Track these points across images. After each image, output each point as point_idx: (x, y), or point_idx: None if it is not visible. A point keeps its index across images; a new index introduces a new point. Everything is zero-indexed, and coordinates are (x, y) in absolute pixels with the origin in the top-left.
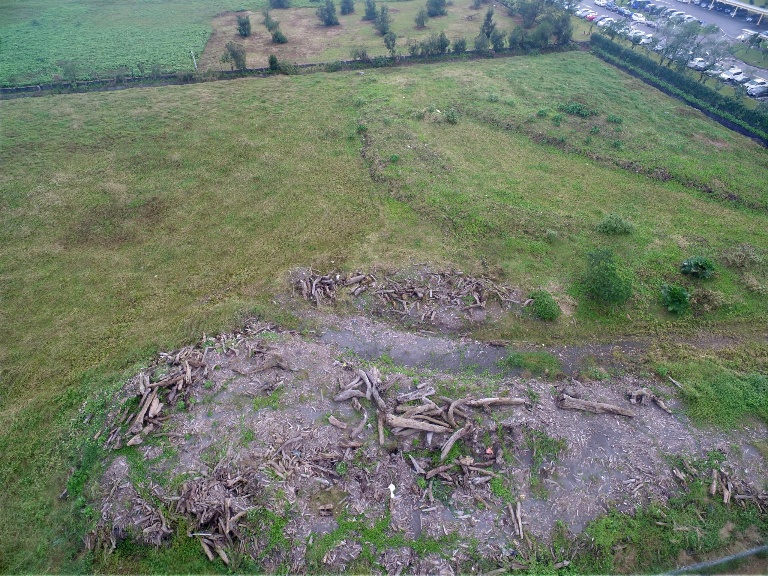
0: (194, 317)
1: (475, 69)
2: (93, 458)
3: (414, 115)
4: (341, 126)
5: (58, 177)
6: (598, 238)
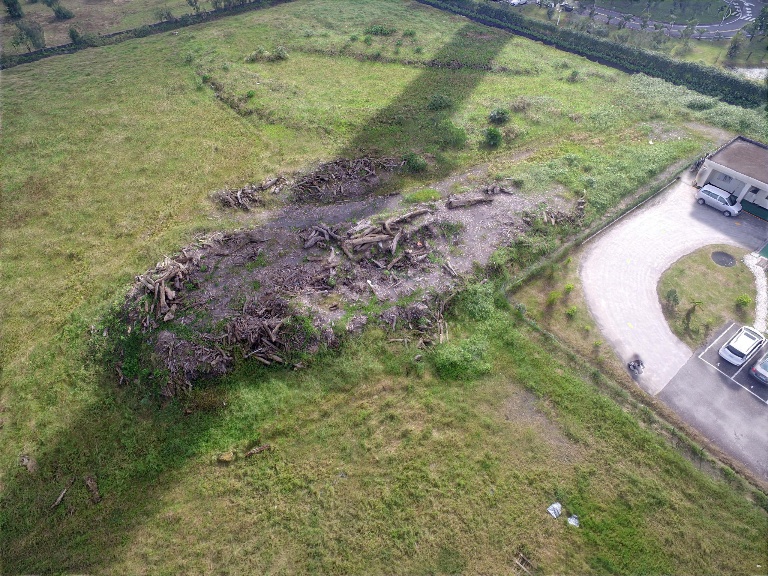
0: (146, 248)
1: (281, 13)
2: (135, 345)
3: (247, 59)
4: (184, 80)
5: None
6: (432, 114)
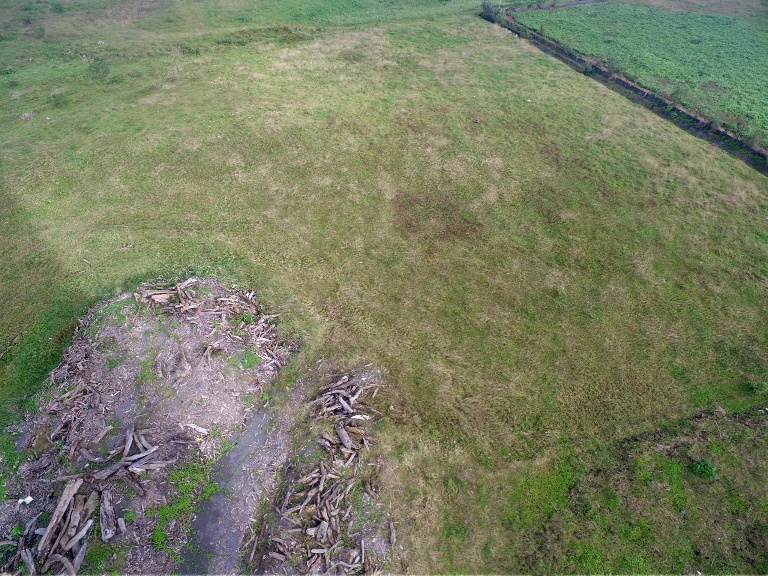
0: None
1: None
2: None
3: None
4: None
5: (493, 160)
6: None
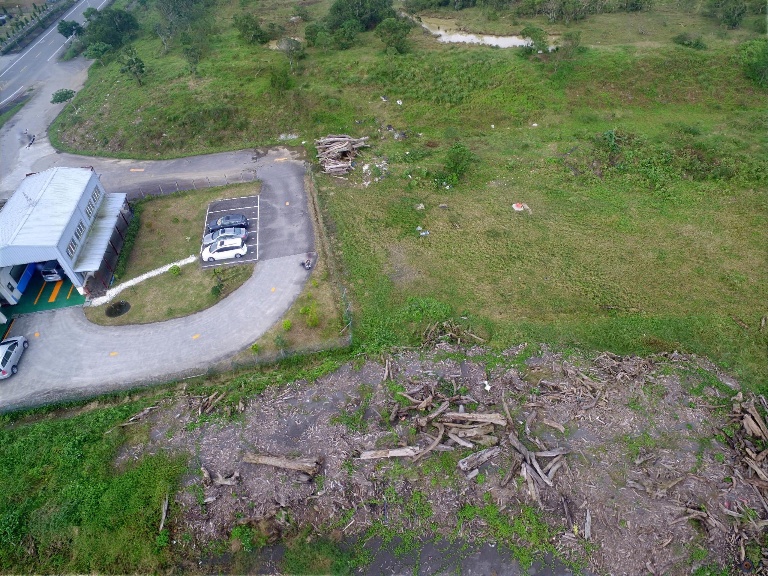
0: None
1: None
2: None
3: None
4: None
5: None
6: None
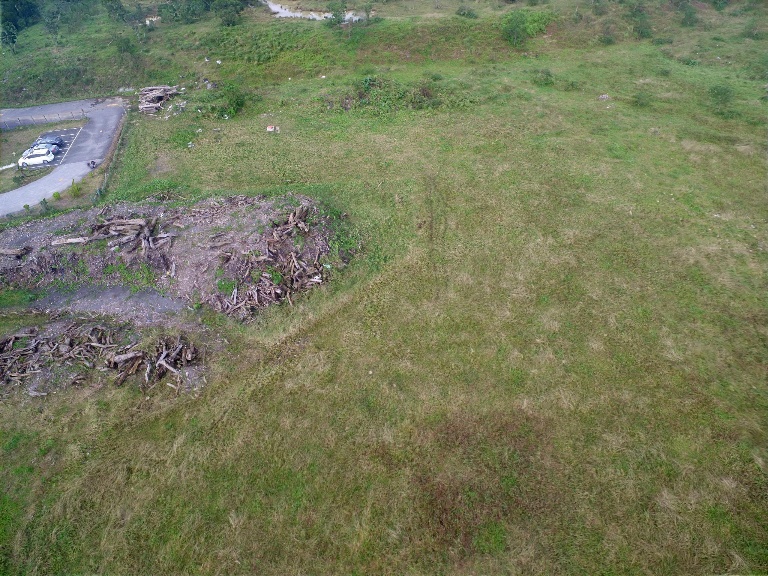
0: (305, 319)
1: None
2: None
3: None
4: None
5: None
6: None
